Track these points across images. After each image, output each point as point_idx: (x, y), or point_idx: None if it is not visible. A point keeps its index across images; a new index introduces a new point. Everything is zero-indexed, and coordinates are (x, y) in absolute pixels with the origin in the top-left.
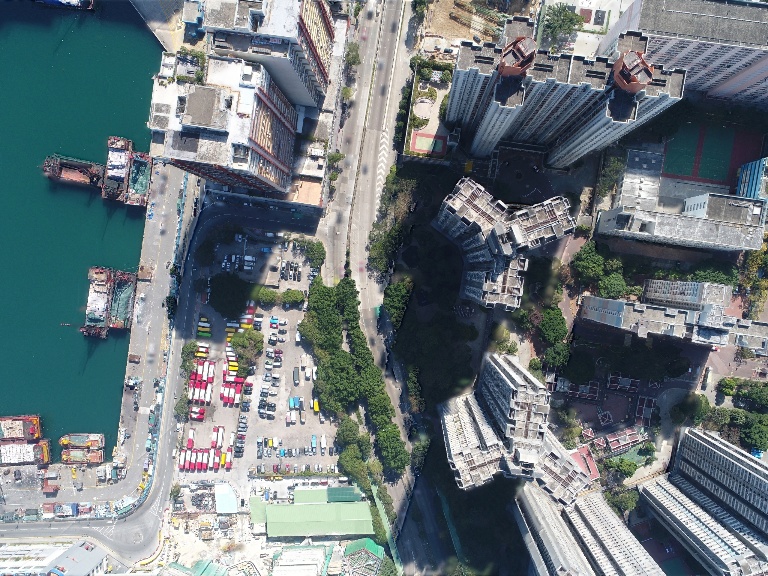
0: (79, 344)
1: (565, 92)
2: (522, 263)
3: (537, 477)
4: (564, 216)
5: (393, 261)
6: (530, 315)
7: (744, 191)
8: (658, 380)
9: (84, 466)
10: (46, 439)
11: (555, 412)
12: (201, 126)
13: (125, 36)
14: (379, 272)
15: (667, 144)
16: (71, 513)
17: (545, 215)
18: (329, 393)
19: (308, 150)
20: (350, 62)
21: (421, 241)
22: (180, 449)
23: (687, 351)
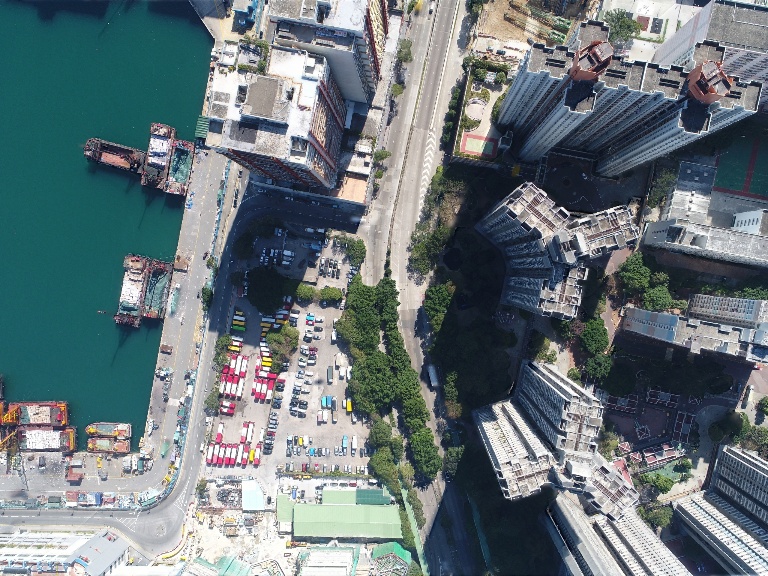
0: (110, 332)
1: (634, 100)
2: (582, 272)
3: (589, 491)
4: (627, 226)
5: (435, 263)
6: (572, 324)
7: None
8: (698, 396)
9: (110, 455)
10: (73, 426)
11: None
12: (261, 117)
13: (172, 22)
14: (419, 273)
15: (719, 157)
16: (95, 502)
17: (608, 224)
18: (364, 394)
19: (355, 146)
20: (401, 59)
21: (464, 244)
22: (208, 443)
23: (729, 368)
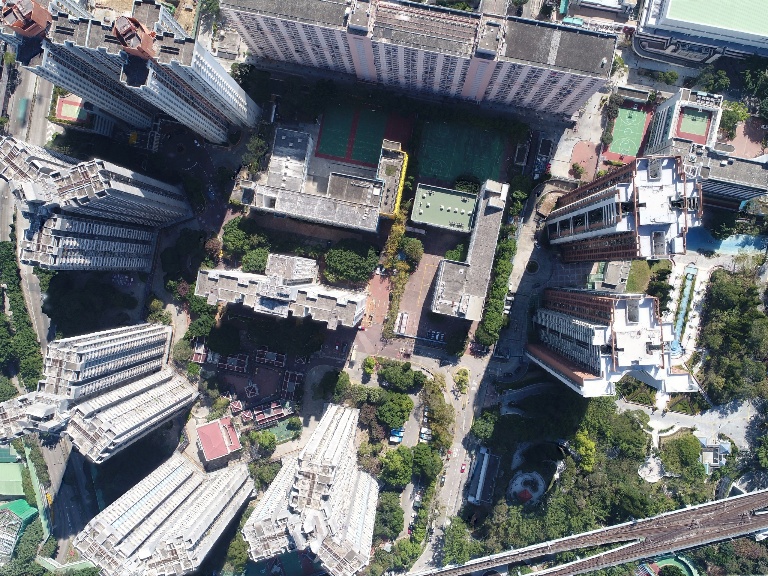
0: None
1: (103, 57)
2: None
3: (44, 430)
4: (97, 178)
5: None
6: (179, 286)
7: None
8: (303, 356)
9: None
10: None
11: None
12: None
13: None
14: None
15: (323, 125)
16: None
17: (79, 176)
18: None
19: None
20: None
21: None
22: None
23: None
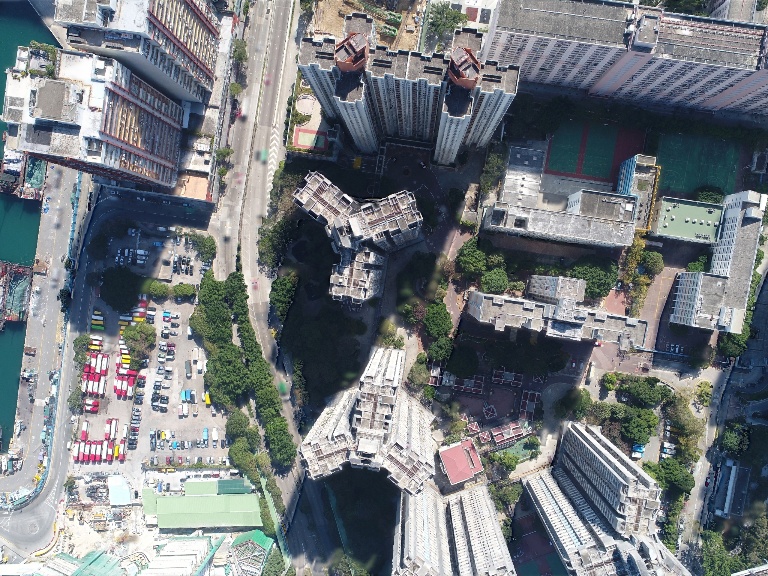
0: None
1: (410, 88)
2: (368, 256)
3: (376, 467)
4: (408, 210)
5: (281, 256)
6: (415, 310)
7: (621, 188)
8: (541, 375)
9: None
10: None
11: (441, 406)
12: (51, 119)
13: (22, 32)
14: (270, 267)
15: (551, 141)
16: None
17: (390, 209)
18: (217, 386)
19: (194, 145)
20: None
21: (308, 236)
22: (75, 441)
23: (571, 346)
